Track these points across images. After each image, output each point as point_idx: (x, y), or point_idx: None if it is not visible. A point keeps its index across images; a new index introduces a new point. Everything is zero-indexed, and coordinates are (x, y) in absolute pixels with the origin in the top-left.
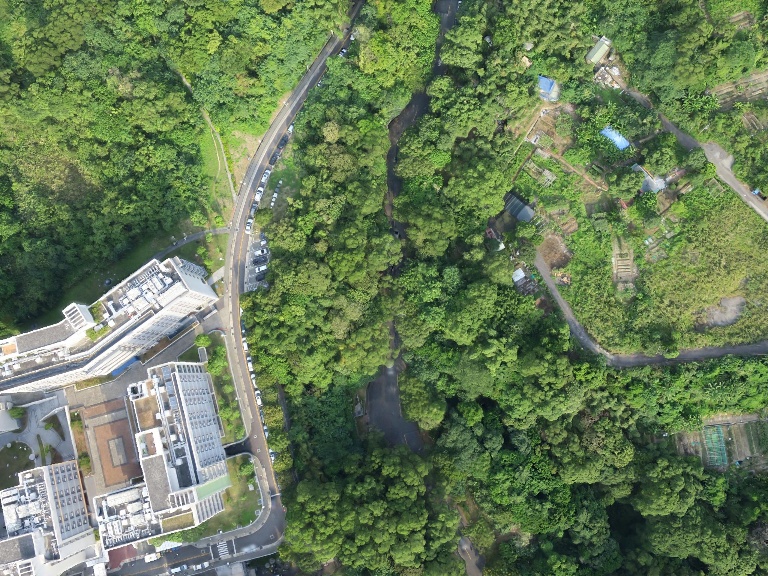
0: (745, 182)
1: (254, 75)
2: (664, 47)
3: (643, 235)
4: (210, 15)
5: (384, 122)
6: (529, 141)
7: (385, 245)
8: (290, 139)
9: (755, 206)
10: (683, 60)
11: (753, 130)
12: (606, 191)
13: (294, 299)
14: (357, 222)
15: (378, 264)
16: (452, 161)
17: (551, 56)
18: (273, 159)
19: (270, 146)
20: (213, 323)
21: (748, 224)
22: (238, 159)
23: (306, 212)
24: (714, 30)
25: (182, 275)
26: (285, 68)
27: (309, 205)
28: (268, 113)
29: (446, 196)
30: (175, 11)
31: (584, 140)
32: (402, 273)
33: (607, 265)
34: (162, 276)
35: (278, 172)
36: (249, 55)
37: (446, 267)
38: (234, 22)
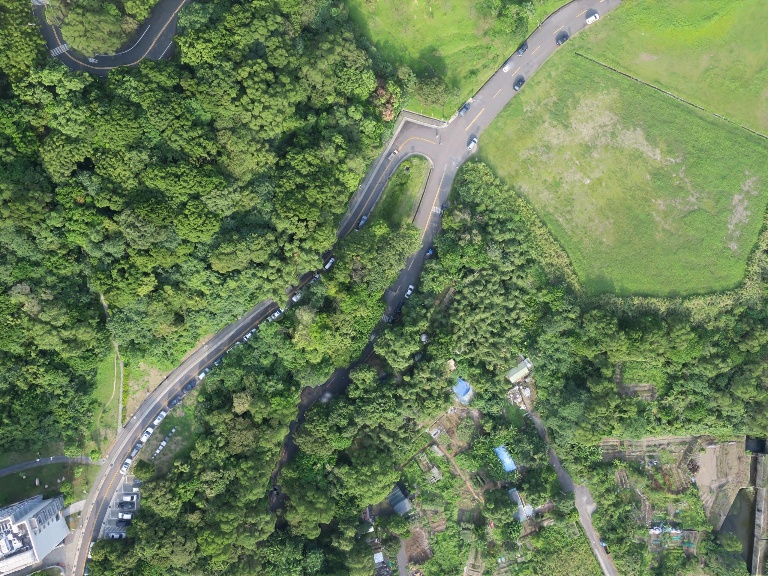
0: (598, 532)
1: (180, 317)
2: (574, 406)
3: (499, 554)
4: (151, 263)
5: (299, 392)
6: (429, 433)
7: (260, 525)
8: (198, 385)
9: (599, 554)
10: (586, 426)
11: (621, 487)
12: (481, 502)
13: (150, 570)
14: (239, 504)
15: (247, 544)
16: (352, 445)
17: (476, 366)
18: (173, 403)
19: (174, 385)
20: (55, 557)
21: (588, 569)
22: (136, 391)
23: (190, 474)
24: (620, 403)
25: (35, 542)
26: (215, 321)
27: (196, 468)
28: (183, 352)
29: (335, 474)
30: (114, 247)
31: (478, 453)
32: (268, 543)
33: (459, 573)
34: (12, 538)
35: (174, 418)
36: (181, 304)
37: (312, 551)
38: (176, 267)
